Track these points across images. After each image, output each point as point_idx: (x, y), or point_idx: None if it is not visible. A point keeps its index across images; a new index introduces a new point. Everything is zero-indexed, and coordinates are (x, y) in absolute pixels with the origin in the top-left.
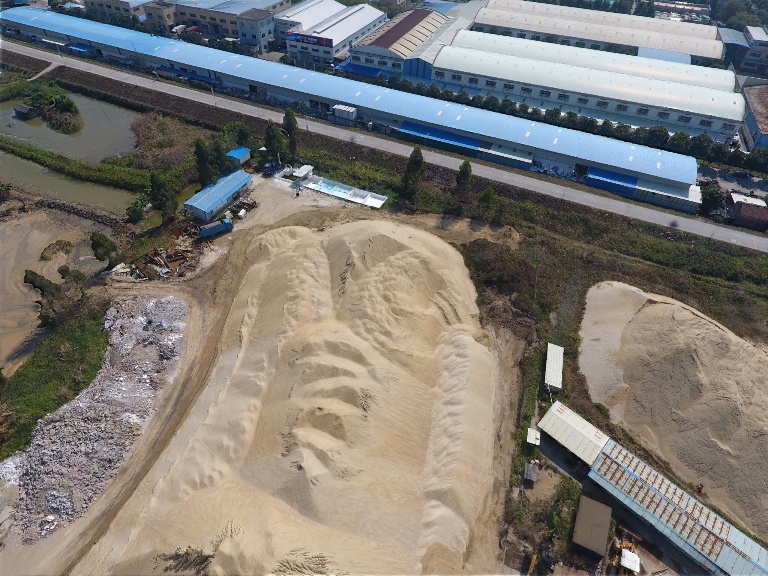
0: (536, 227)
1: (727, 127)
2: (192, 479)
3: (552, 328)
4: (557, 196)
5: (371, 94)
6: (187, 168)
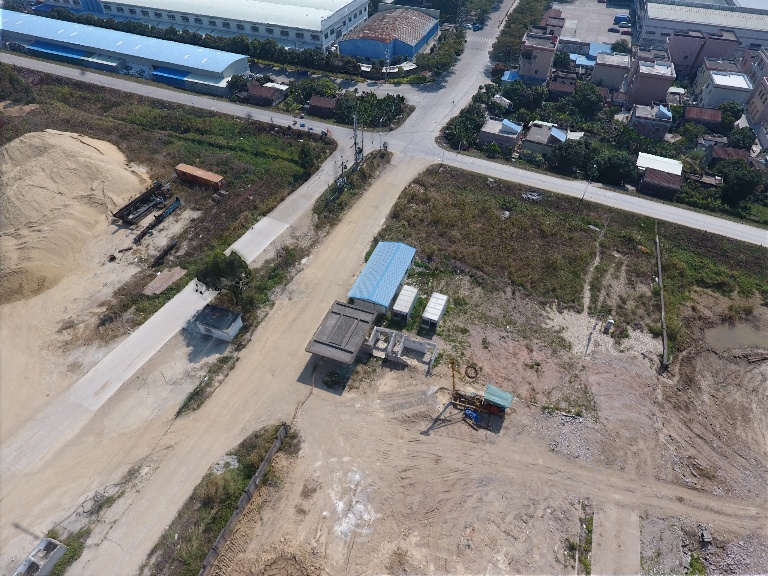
0: (55, 103)
1: (315, 38)
2: None
3: None
4: (102, 84)
5: (16, 20)
6: None
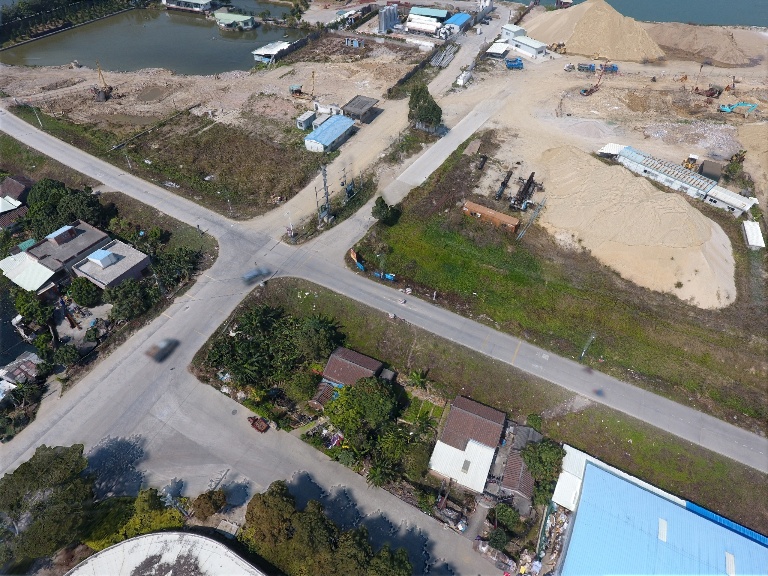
0: None
1: None
2: None
3: (761, 267)
4: None
5: None
6: None
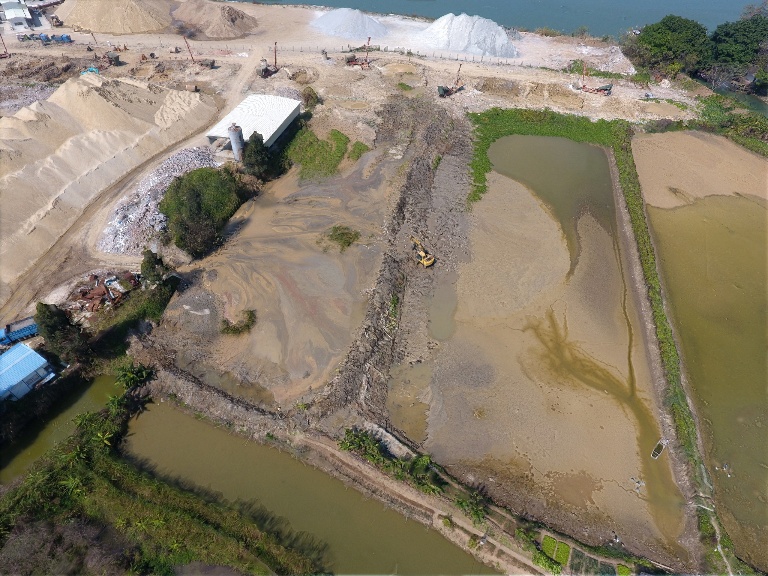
0: None
1: None
2: (110, 135)
3: None
4: None
5: None
6: (8, 491)
